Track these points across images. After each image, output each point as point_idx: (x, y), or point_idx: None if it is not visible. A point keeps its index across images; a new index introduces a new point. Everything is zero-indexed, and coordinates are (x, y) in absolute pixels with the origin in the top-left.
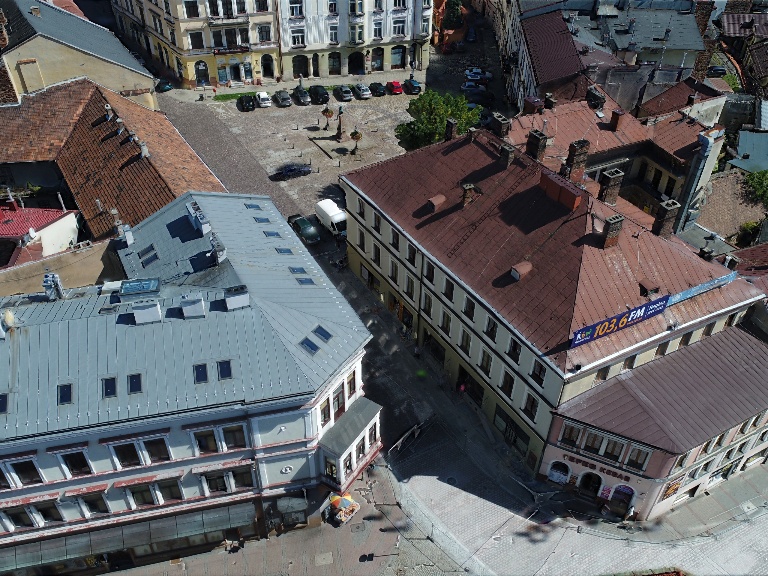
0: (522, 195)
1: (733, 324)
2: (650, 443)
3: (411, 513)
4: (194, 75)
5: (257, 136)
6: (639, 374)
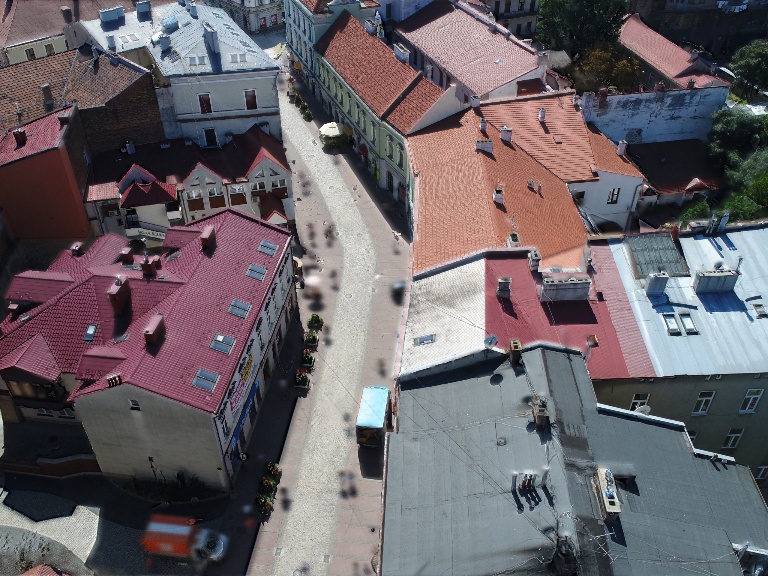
0: None
1: None
2: None
3: None
4: None
5: None
6: None
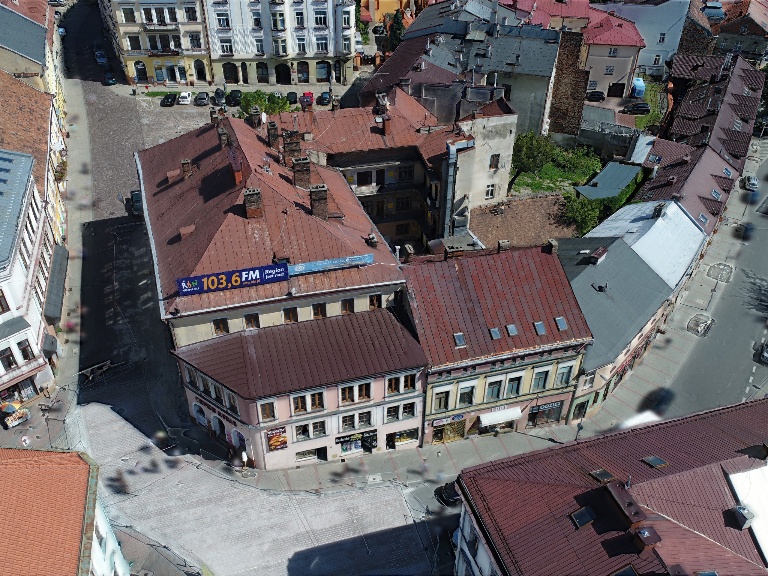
0: (219, 171)
1: (383, 306)
2: (229, 386)
3: (70, 429)
4: (134, 73)
5: (160, 127)
6: (263, 333)
